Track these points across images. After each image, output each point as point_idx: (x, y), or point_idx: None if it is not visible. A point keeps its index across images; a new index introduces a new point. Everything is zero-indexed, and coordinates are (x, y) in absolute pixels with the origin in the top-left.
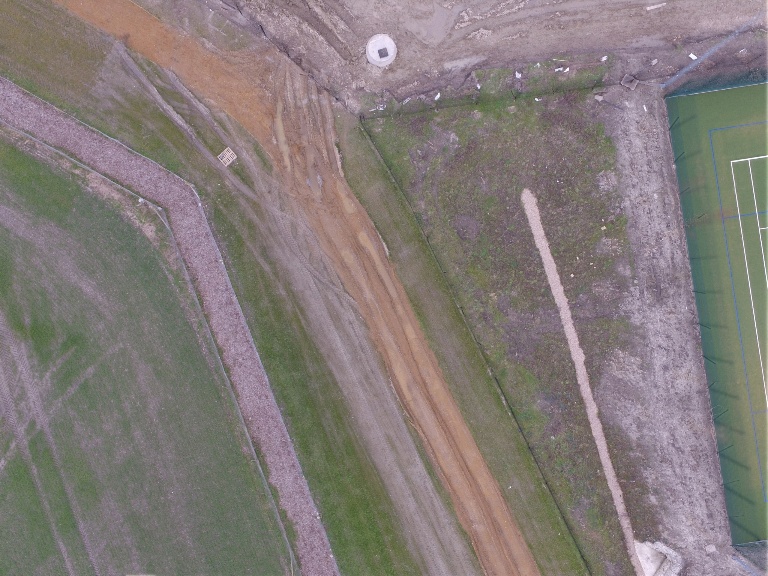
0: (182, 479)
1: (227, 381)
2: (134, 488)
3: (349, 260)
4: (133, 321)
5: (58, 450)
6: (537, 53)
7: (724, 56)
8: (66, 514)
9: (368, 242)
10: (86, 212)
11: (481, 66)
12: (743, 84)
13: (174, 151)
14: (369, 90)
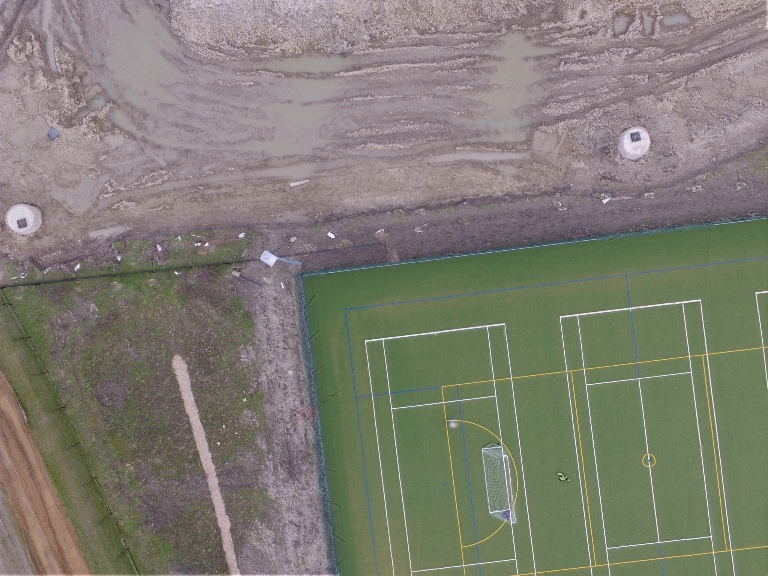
0: None
1: None
2: None
3: None
4: None
5: None
6: (181, 225)
7: (362, 235)
8: None
9: (10, 408)
10: None
11: (125, 236)
12: (380, 264)
13: None
14: (13, 257)
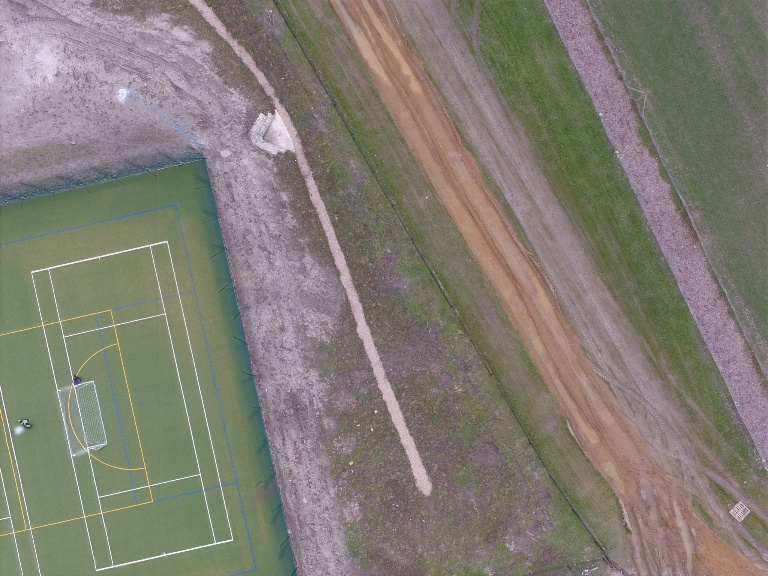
0: (759, 180)
1: (722, 283)
2: None
3: (606, 414)
4: None
5: None
6: None
7: None
8: None
9: (588, 434)
10: None
11: None
12: None
13: None
14: None
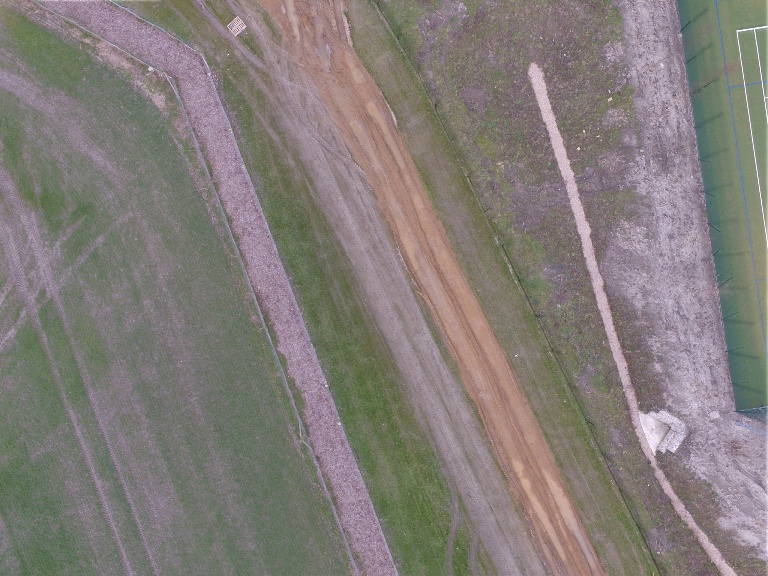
0: (191, 348)
1: (236, 250)
2: (144, 356)
3: (357, 130)
4: (143, 190)
5: (68, 318)
6: None
7: None
8: (76, 382)
9: (376, 113)
10: (96, 81)
11: None
12: None
13: (184, 21)
14: None
